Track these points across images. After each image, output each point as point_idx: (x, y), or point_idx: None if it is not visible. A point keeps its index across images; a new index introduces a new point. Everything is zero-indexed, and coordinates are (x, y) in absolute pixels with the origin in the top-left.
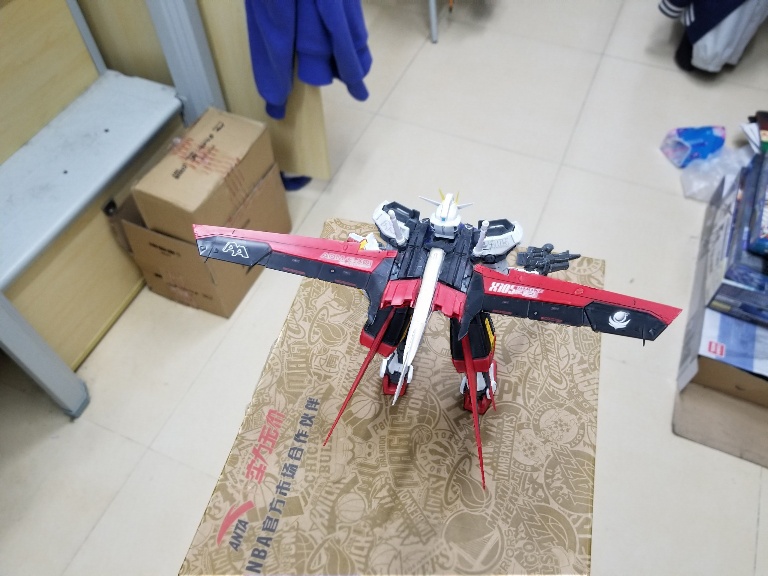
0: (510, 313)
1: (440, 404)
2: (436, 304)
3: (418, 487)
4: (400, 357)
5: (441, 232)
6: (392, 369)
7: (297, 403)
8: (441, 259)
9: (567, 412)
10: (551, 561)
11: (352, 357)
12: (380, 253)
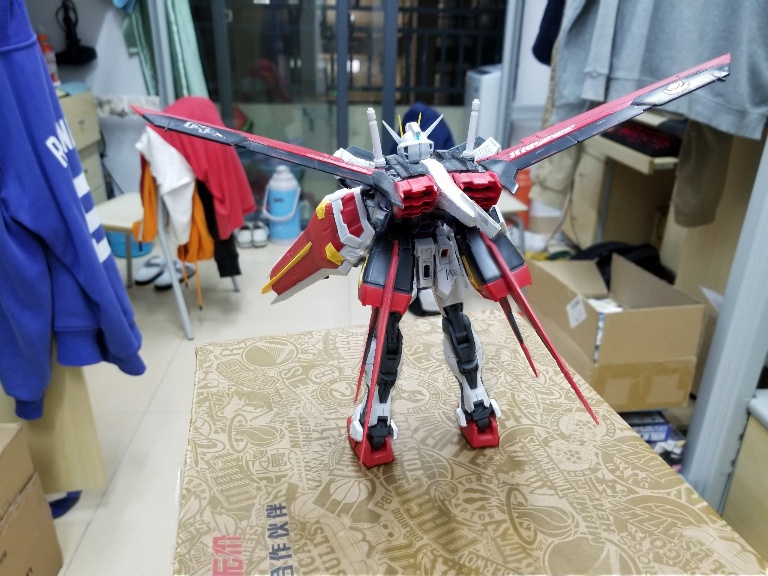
0: (554, 151)
1: (442, 455)
2: (463, 182)
3: (480, 543)
4: (382, 390)
5: (417, 156)
6: (374, 416)
7: (252, 517)
8: (437, 161)
9: (580, 412)
10: (694, 544)
11: (302, 448)
12: (367, 167)
